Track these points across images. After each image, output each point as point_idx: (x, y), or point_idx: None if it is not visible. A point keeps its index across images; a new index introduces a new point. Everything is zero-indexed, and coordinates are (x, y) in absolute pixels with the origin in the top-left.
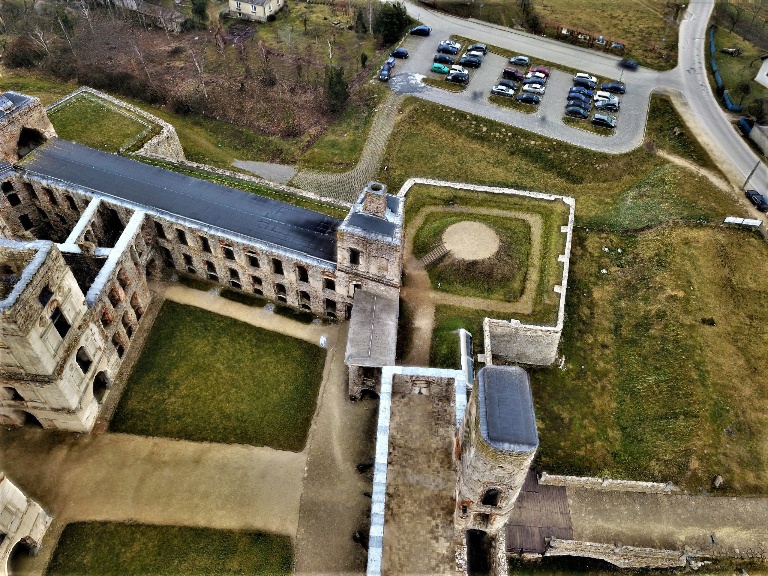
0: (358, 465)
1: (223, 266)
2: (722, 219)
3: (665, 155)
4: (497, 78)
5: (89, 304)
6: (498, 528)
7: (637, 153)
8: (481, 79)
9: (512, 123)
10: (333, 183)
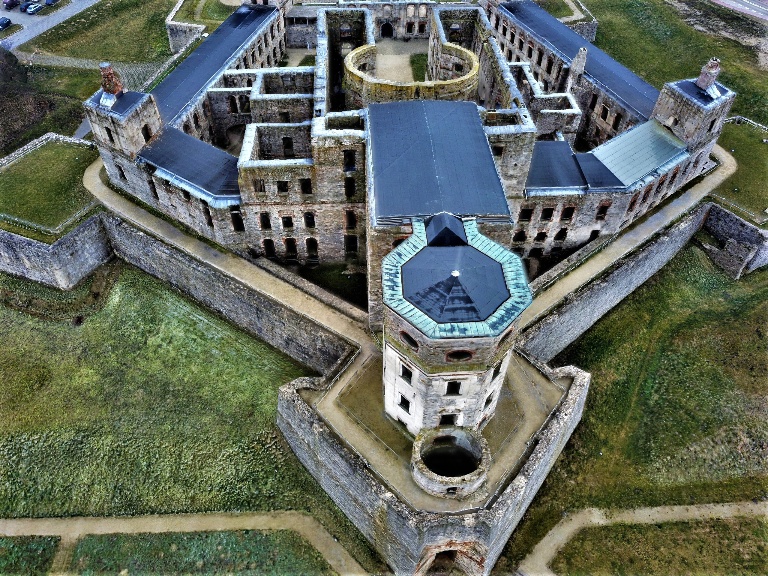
0: None
1: None
2: None
3: None
4: (8, 12)
5: None
6: None
7: None
8: (7, 17)
9: (82, 9)
10: (132, 79)
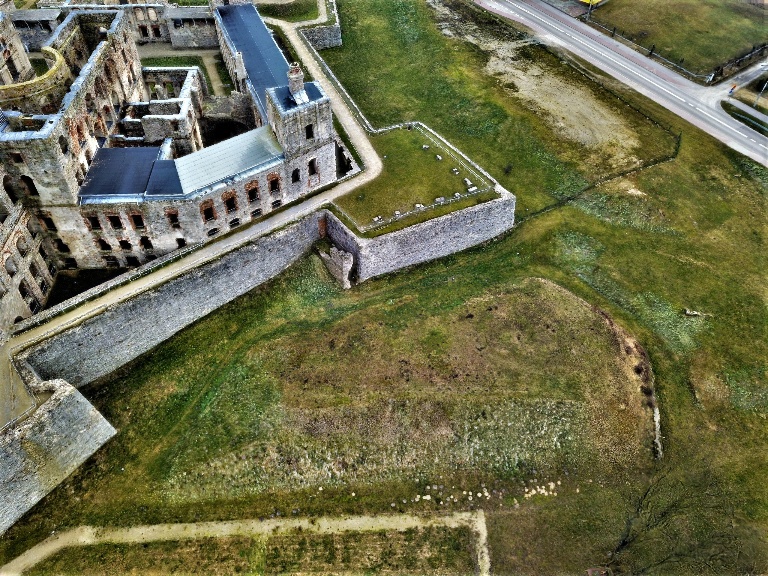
0: None
1: None
2: None
3: None
4: None
5: None
6: None
7: None
8: None
9: None
10: None
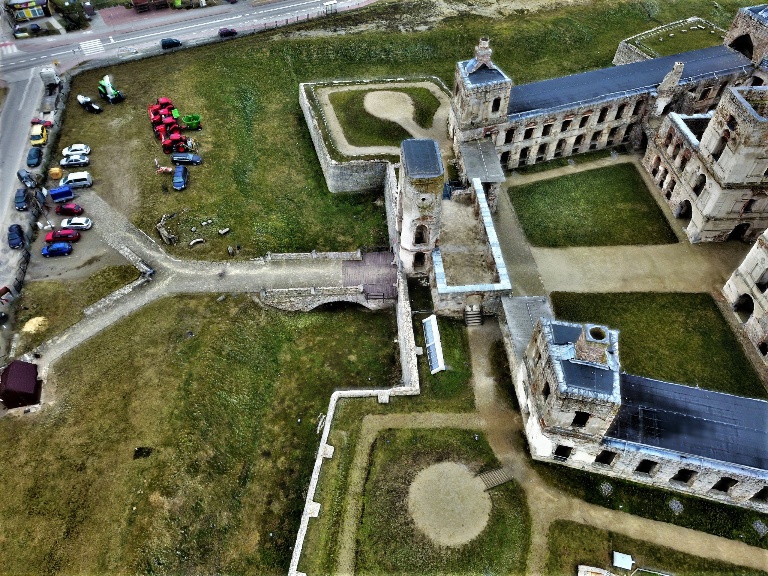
0: None
1: None
2: None
3: None
4: None
5: None
6: None
7: None
8: None
9: None
10: None
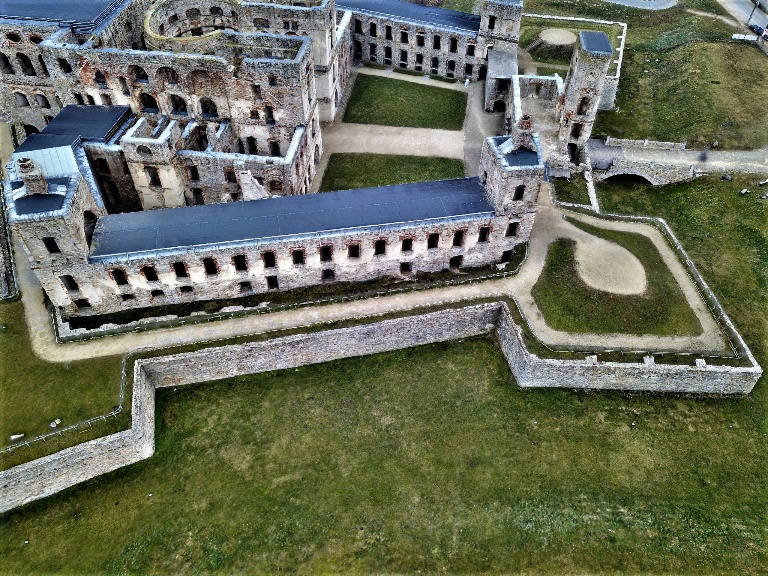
0: (495, 135)
1: (398, 49)
2: (730, 38)
3: (693, 11)
4: None
5: None
6: (584, 141)
7: (672, 9)
8: None
9: None
10: None
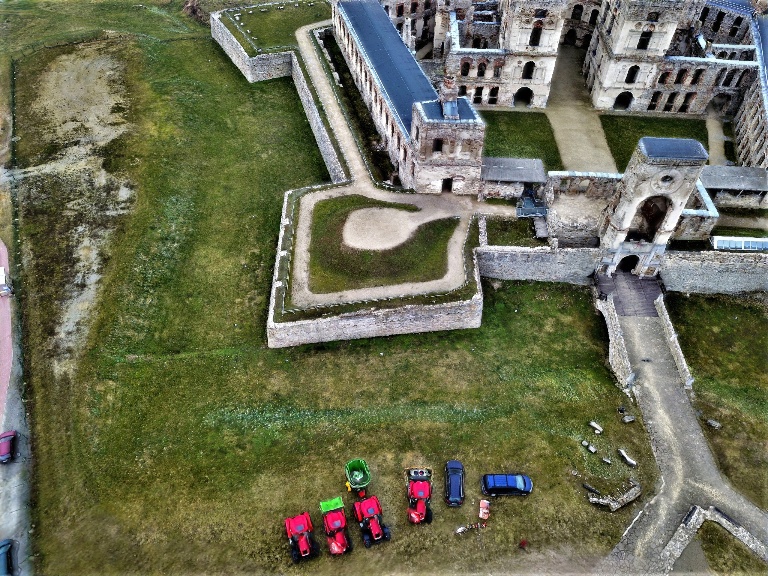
0: None
1: None
2: None
3: None
4: None
5: (667, 58)
6: (604, 246)
7: None
8: None
9: None
10: None
